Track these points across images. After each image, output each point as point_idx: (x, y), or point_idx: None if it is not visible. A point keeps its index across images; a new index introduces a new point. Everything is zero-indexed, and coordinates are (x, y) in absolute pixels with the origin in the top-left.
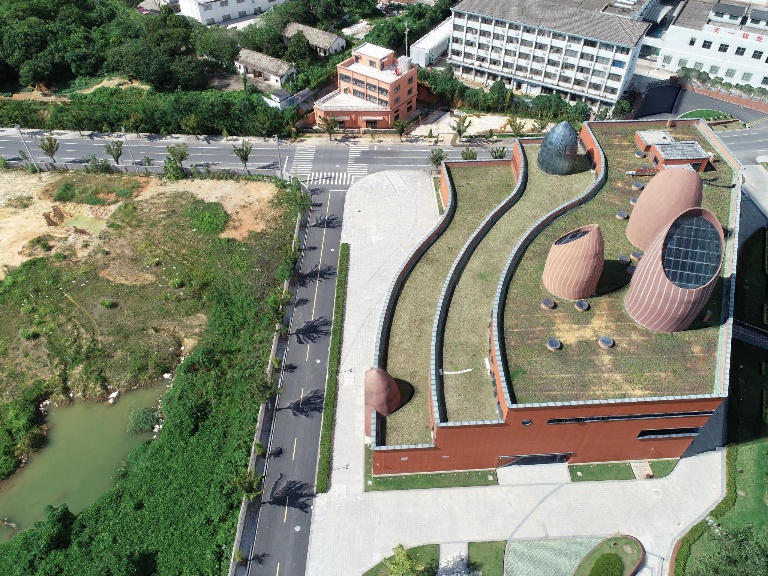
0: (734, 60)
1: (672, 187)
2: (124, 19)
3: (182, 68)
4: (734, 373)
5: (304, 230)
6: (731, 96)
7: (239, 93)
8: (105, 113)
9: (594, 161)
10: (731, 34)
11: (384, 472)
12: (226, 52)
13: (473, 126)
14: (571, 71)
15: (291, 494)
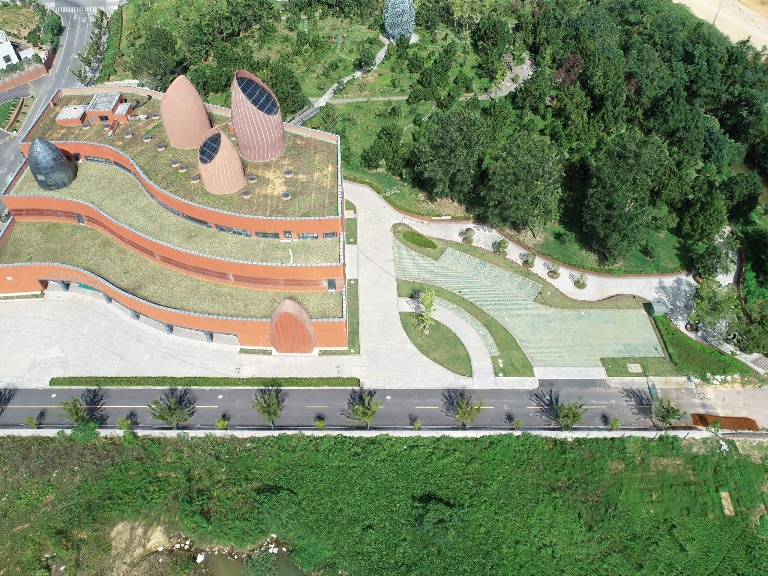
0: None
1: (186, 91)
2: None
3: None
4: None
5: None
6: None
7: None
8: None
9: (72, 154)
10: None
11: None
12: None
13: None
14: None
15: None
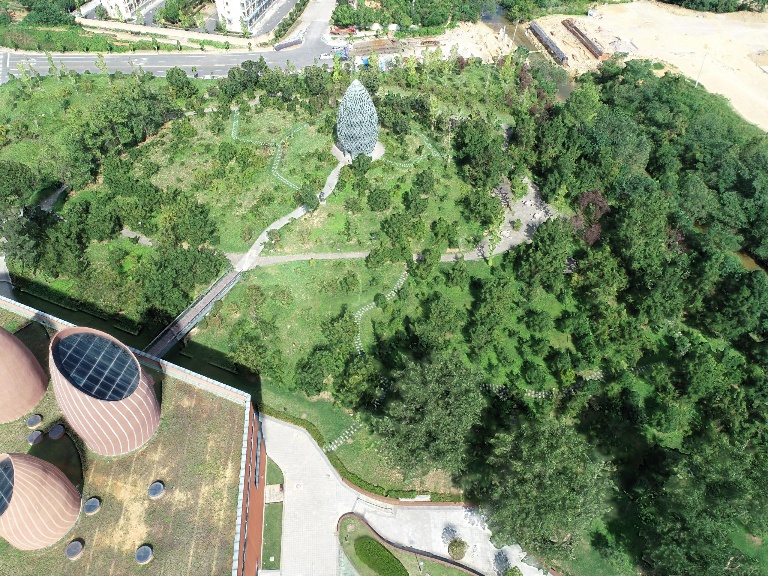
0: None
1: None
2: None
3: None
4: None
5: None
6: None
7: None
8: None
9: None
10: None
11: None
12: None
13: None
14: None
15: None
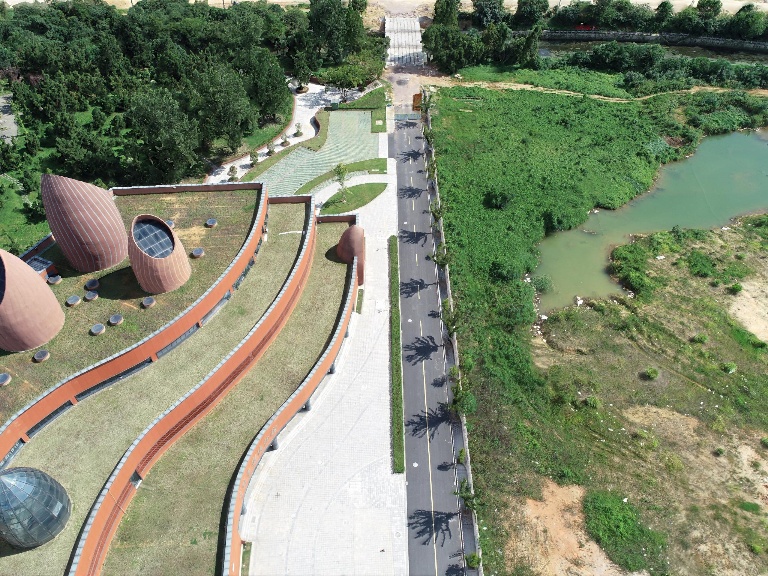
0: None
1: None
2: None
3: None
4: None
5: (463, 503)
6: None
7: None
8: None
9: None
10: None
11: None
12: None
13: None
14: None
15: (414, 237)
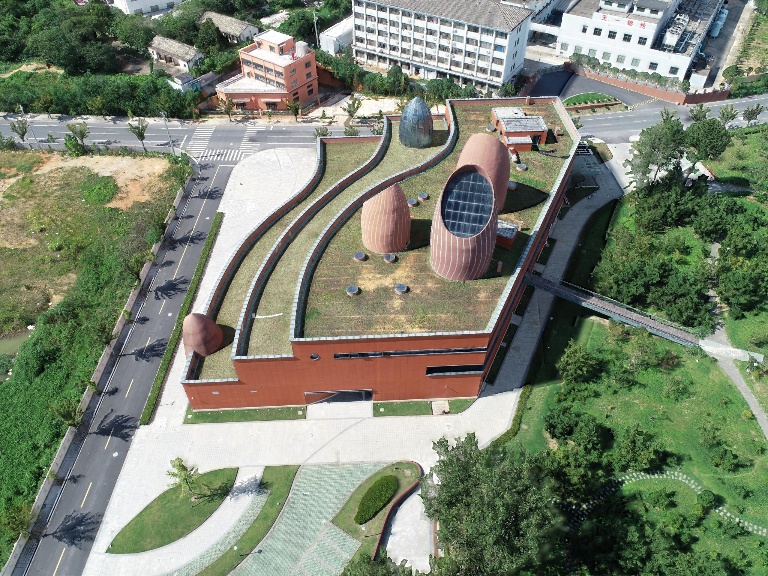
0: (623, 46)
1: (476, 151)
2: (56, 10)
3: (92, 53)
4: (548, 325)
5: (185, 201)
6: (619, 80)
7: (147, 77)
8: (19, 95)
9: None
10: (617, 21)
11: (202, 407)
12: (139, 39)
13: (369, 108)
14: (460, 56)
15: (117, 426)
